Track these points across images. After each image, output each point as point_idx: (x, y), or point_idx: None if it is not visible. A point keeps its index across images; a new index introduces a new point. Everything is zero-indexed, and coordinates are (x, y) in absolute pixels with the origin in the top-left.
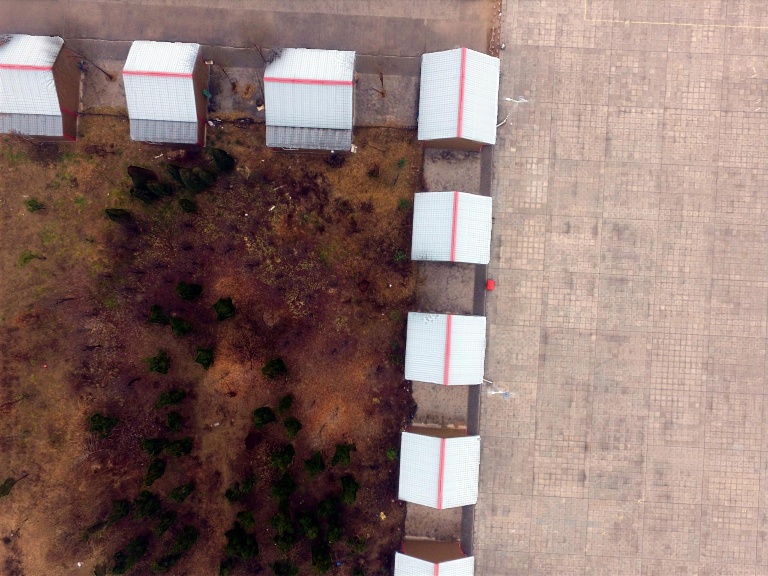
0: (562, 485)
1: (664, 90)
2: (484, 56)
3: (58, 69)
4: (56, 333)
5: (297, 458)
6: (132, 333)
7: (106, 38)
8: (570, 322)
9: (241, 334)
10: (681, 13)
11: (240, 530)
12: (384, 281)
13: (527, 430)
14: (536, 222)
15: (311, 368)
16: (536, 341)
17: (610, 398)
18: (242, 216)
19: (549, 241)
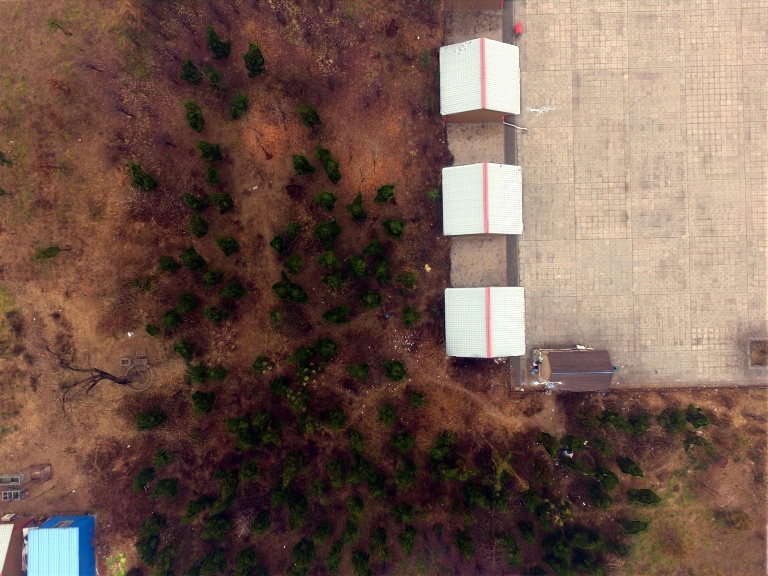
0: (605, 227)
1: None
2: None
3: None
4: (88, 107)
5: (338, 216)
6: (164, 102)
7: None
8: (601, 63)
9: (272, 96)
10: None
11: (288, 280)
12: (412, 33)
13: (566, 175)
14: None
15: (345, 125)
16: (568, 85)
17: (647, 136)
18: None
19: None
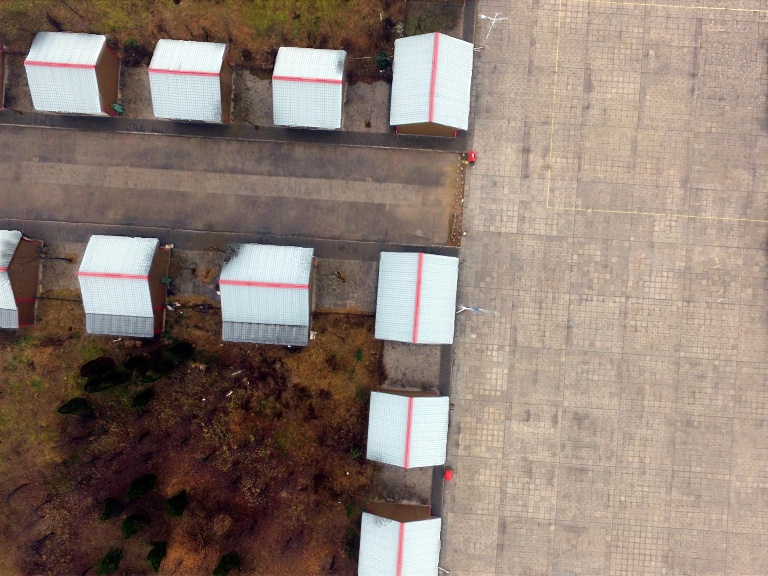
0: None
1: (626, 279)
2: (442, 258)
3: (14, 266)
4: (9, 519)
5: None
6: (86, 520)
7: (67, 220)
8: (529, 512)
9: (196, 522)
10: (644, 202)
11: None
12: (341, 469)
13: None
14: (496, 409)
15: (266, 557)
16: (494, 530)
17: None
18: (199, 401)
19: (509, 429)
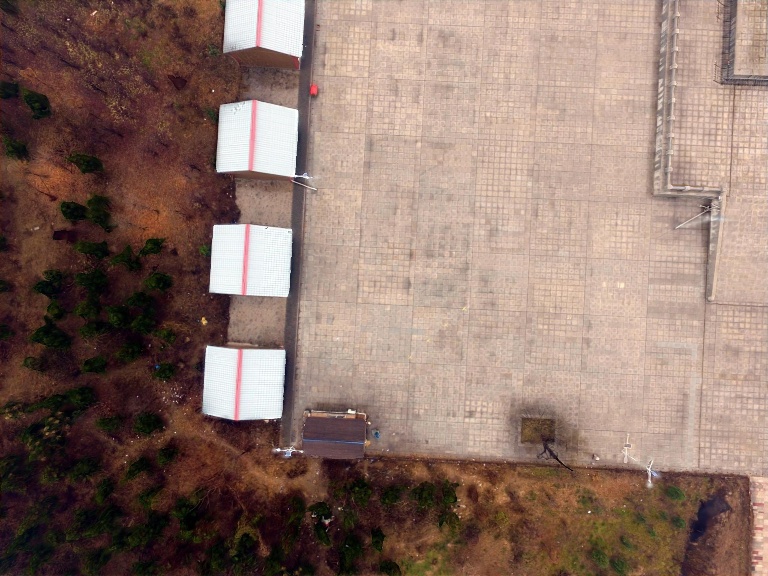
0: (387, 292)
1: None
2: None
3: None
4: None
5: None
6: None
7: None
8: (395, 129)
9: (61, 138)
10: None
11: (51, 325)
12: (206, 86)
13: (352, 237)
14: (361, 29)
15: (132, 172)
16: (361, 148)
17: (435, 205)
18: (64, 21)
19: (374, 48)
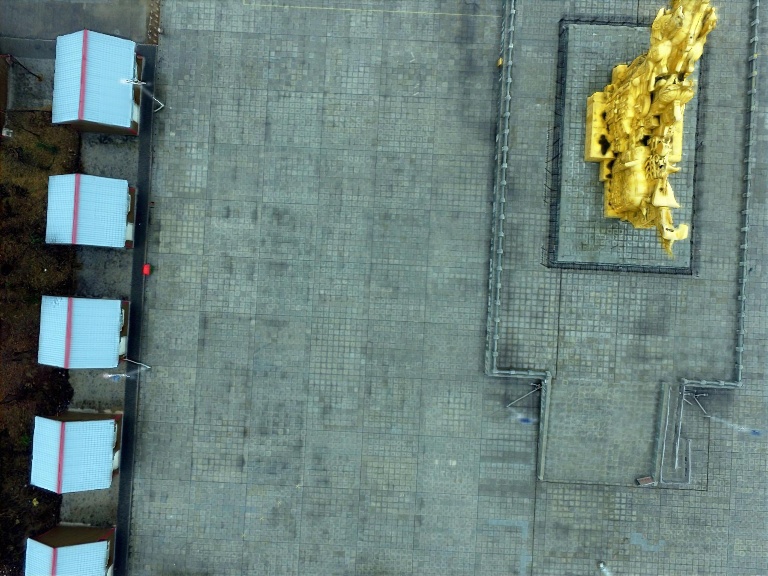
0: (220, 470)
1: (323, 75)
2: (113, 39)
3: None
4: None
5: None
6: None
7: None
8: (229, 306)
9: None
10: None
11: None
12: (39, 265)
13: (186, 415)
14: (196, 206)
15: None
16: (195, 326)
17: (269, 383)
18: None
19: (209, 225)
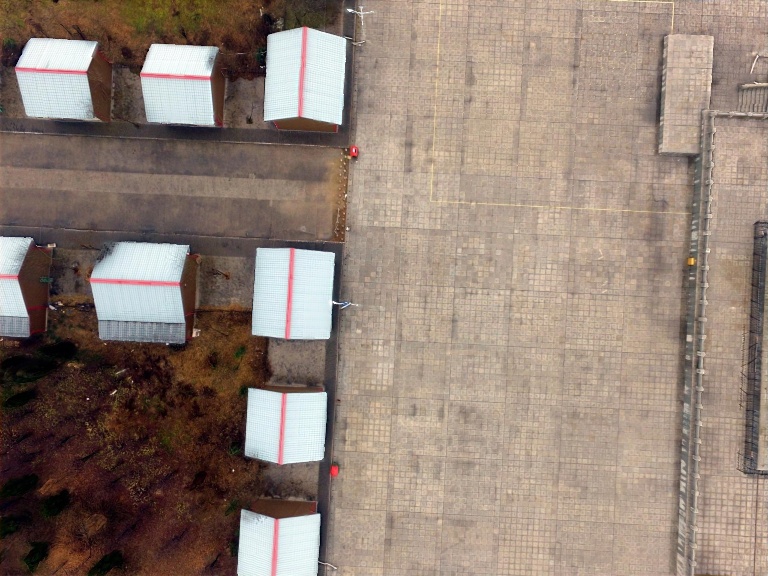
0: None
1: (510, 272)
2: (316, 253)
3: None
4: None
5: None
6: None
7: None
8: (416, 506)
9: (80, 521)
10: (527, 195)
11: None
12: (227, 466)
13: None
14: (382, 404)
15: (152, 555)
16: (382, 525)
17: None
18: (83, 401)
19: (395, 424)
